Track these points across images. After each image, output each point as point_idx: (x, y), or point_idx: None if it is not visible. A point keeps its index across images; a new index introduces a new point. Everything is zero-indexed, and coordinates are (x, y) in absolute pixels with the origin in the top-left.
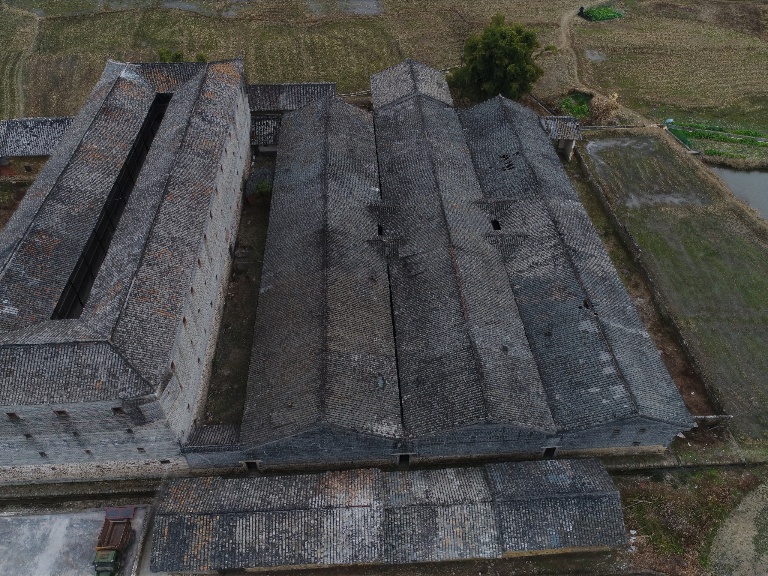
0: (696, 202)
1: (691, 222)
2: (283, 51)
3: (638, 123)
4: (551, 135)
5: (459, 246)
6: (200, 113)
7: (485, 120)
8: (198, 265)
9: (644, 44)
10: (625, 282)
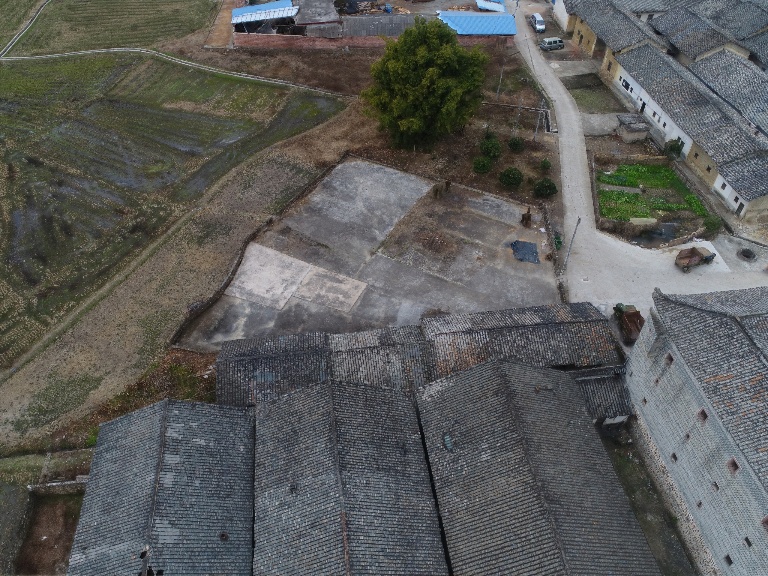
0: None
1: None
2: None
3: None
4: None
5: None
6: None
7: None
8: (767, 518)
9: None
10: None
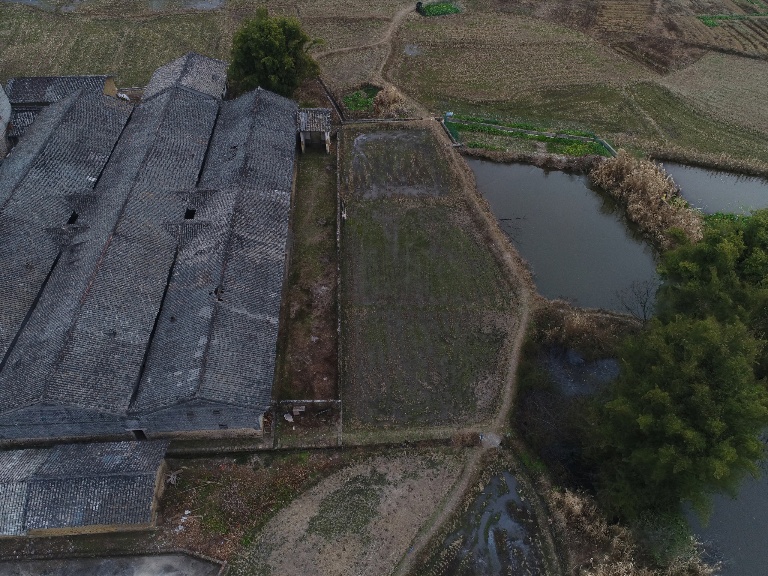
0: (434, 193)
1: (418, 213)
2: (101, 45)
3: (417, 116)
4: (300, 127)
5: (124, 234)
6: None
7: (237, 112)
8: None
9: (465, 39)
10: (318, 271)
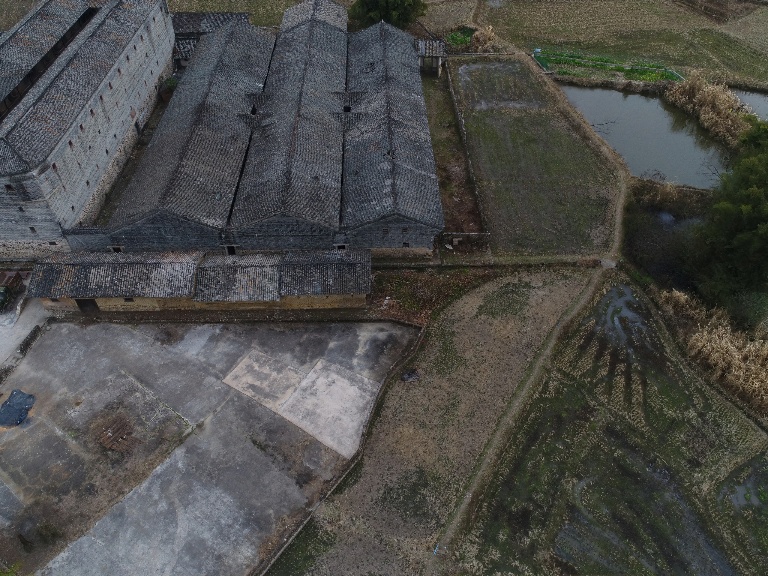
0: (534, 107)
1: (523, 120)
2: None
3: (510, 51)
4: (420, 52)
5: (305, 116)
6: (115, 17)
7: (366, 40)
8: (91, 113)
9: None
10: (450, 157)
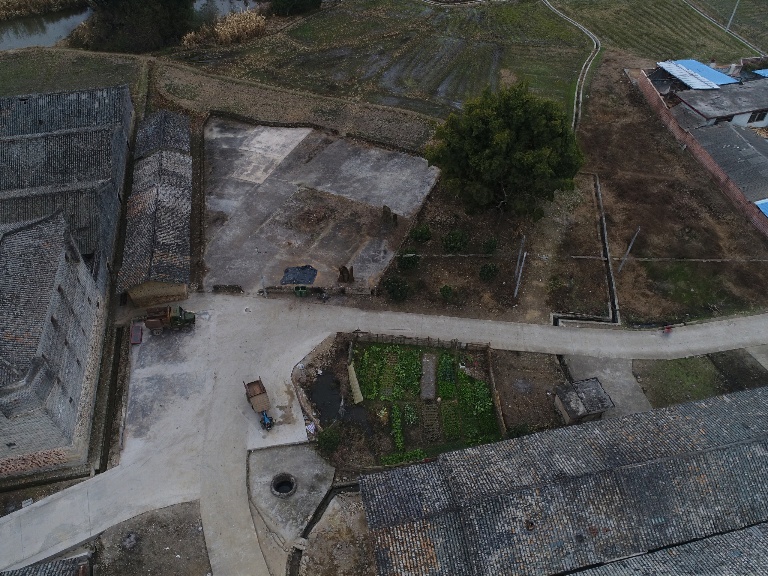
0: None
1: None
2: None
3: None
4: None
5: None
6: None
7: None
8: None
9: None
10: None
